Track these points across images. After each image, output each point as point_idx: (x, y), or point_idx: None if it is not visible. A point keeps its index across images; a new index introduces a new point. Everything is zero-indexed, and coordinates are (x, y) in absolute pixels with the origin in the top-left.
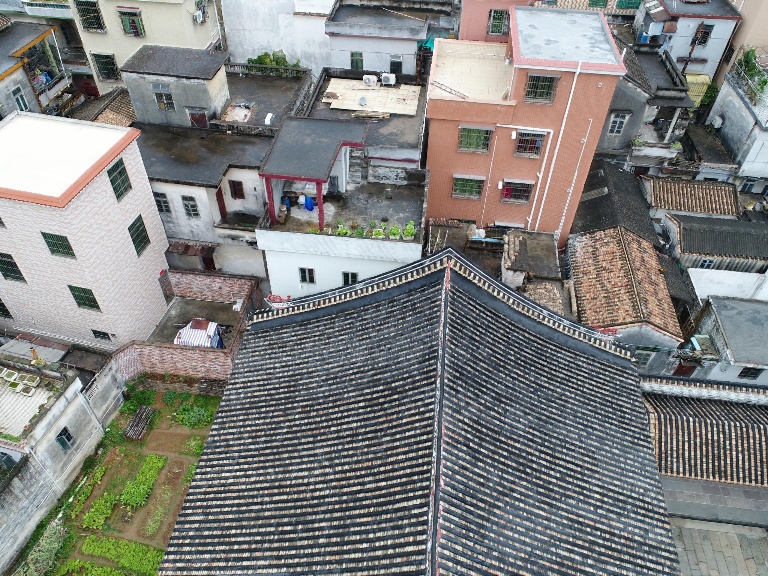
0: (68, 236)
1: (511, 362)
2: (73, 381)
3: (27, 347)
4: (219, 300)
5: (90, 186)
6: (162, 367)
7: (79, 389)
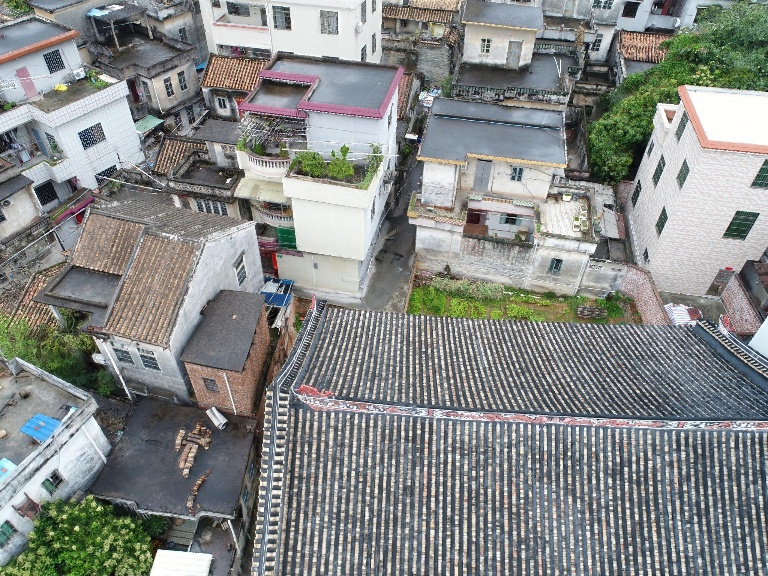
0: (690, 171)
1: (766, 538)
2: (592, 243)
3: (612, 220)
4: (737, 329)
5: (740, 156)
6: (642, 306)
7: (590, 252)
